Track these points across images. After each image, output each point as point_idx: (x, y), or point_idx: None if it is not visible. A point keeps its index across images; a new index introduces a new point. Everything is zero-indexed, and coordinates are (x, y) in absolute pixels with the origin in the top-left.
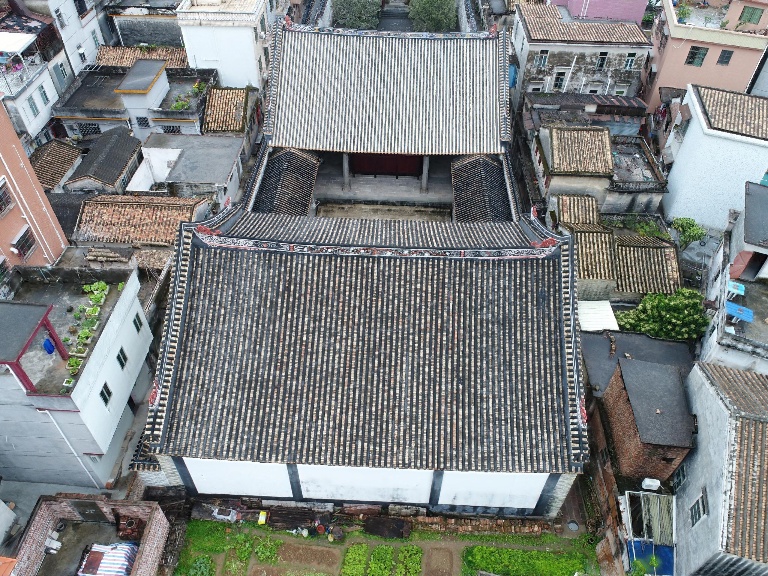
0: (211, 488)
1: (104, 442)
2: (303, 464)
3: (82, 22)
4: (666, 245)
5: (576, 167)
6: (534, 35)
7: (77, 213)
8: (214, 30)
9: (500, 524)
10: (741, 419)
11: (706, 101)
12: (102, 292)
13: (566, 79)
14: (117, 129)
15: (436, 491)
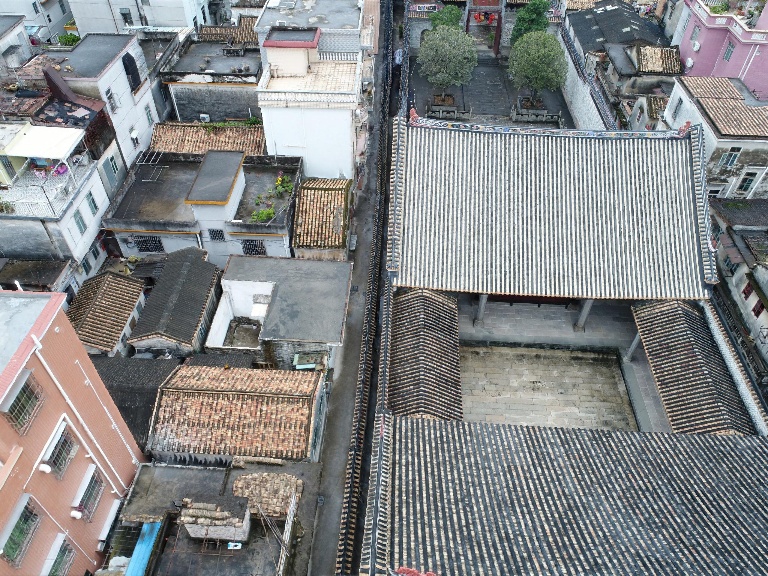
0: None
1: None
2: None
3: (135, 98)
4: None
5: None
6: (723, 128)
7: (150, 402)
8: (303, 112)
9: None
10: None
11: None
12: None
13: (756, 180)
14: (188, 252)
15: None
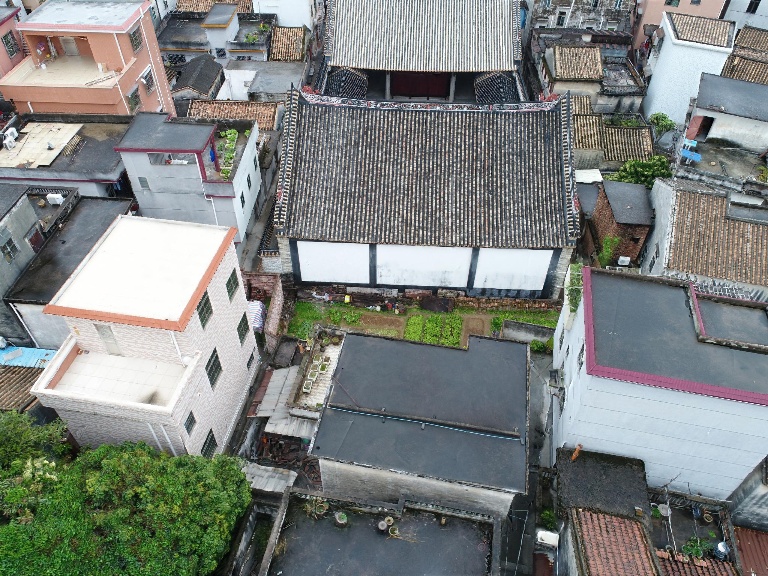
0: (312, 275)
1: (241, 234)
2: (382, 244)
3: None
4: (643, 127)
5: (574, 74)
6: None
7: (185, 110)
8: None
9: (518, 302)
10: (680, 192)
11: (676, 22)
12: (235, 135)
13: (567, 18)
14: (203, 56)
15: (472, 273)
